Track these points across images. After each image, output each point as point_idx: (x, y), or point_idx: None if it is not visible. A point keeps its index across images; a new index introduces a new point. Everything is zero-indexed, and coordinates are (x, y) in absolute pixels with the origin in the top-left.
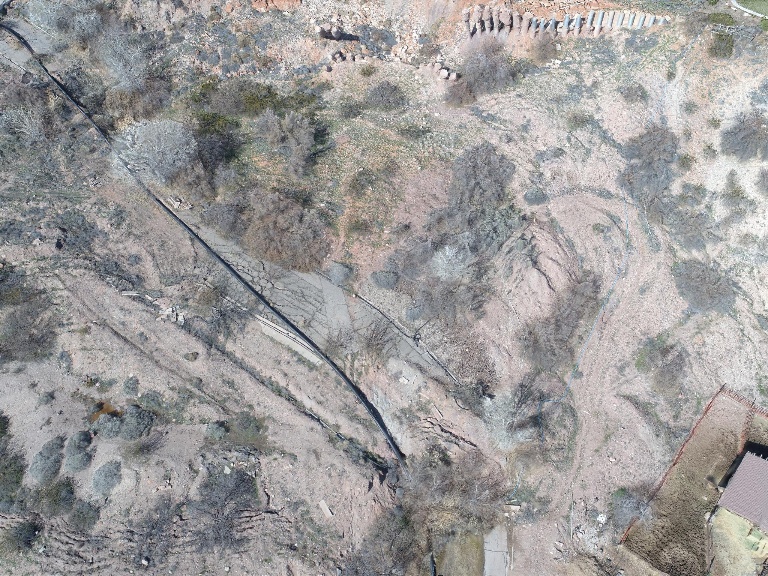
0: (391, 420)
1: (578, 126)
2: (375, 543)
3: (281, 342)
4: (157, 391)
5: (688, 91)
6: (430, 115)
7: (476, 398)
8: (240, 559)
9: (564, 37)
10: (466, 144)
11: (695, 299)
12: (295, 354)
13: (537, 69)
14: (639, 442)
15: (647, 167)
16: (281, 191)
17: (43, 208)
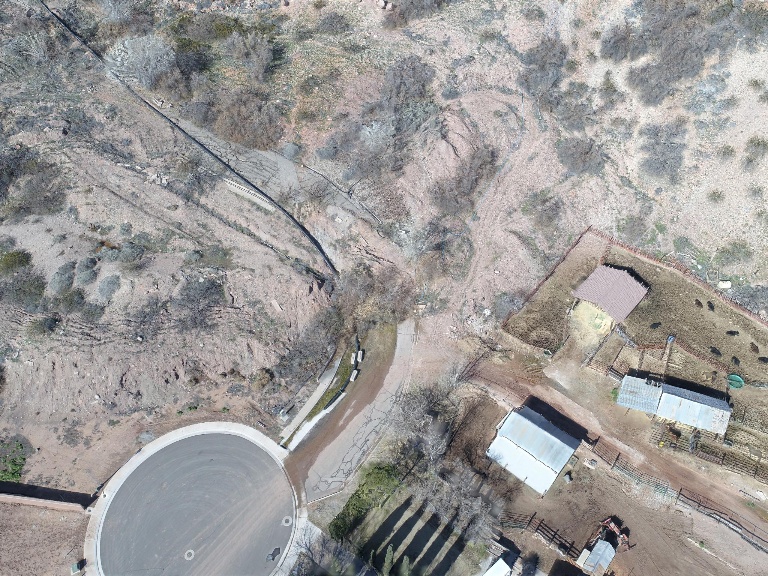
0: (328, 247)
1: (487, 40)
2: (315, 332)
3: (243, 196)
4: (146, 232)
5: (577, 11)
6: (370, 37)
7: (393, 230)
8: (212, 338)
9: None
10: (397, 57)
11: (572, 165)
12: (254, 204)
13: None
14: (518, 260)
15: (541, 70)
16: None
17: (50, 107)
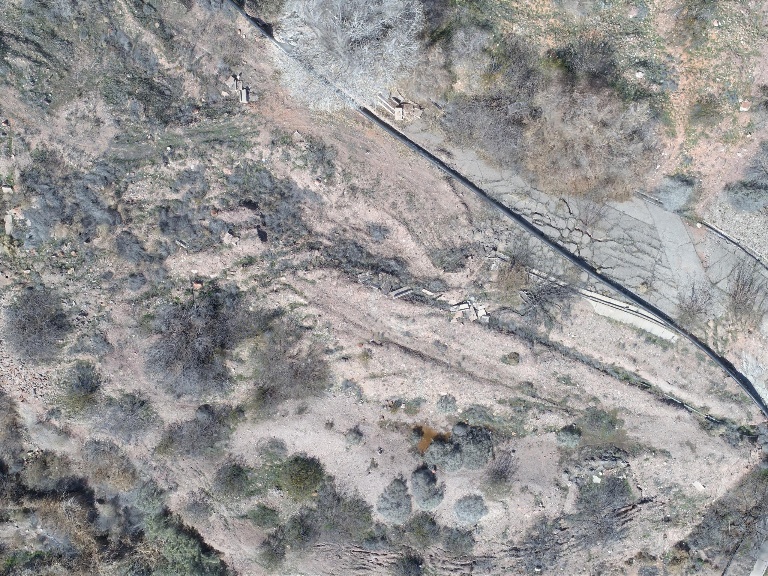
0: (766, 389)
1: None
2: (737, 490)
3: (622, 321)
4: (481, 405)
5: None
6: None
7: None
8: (622, 543)
9: None
10: None
11: None
12: (642, 333)
13: None
14: None
15: None
16: (564, 56)
17: (196, 169)
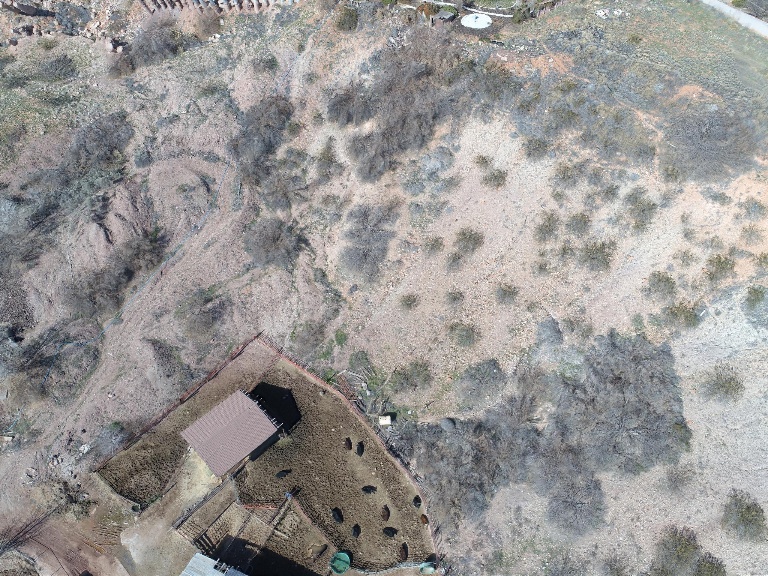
0: None
1: (205, 95)
2: None
3: None
4: None
5: (312, 62)
6: (89, 86)
7: None
8: None
9: (228, 13)
10: (104, 112)
11: (258, 254)
12: None
13: (199, 43)
14: (143, 380)
15: None
16: None
17: None
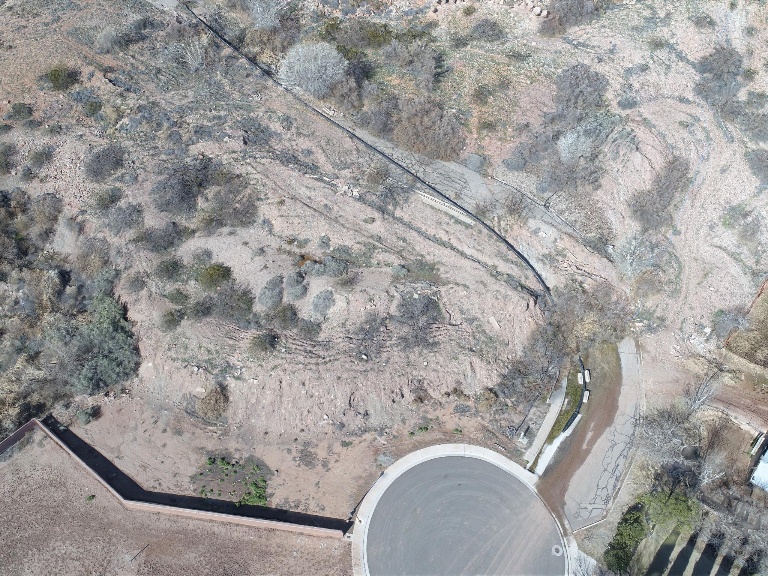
0: (536, 262)
1: (658, 48)
2: (532, 350)
3: (440, 209)
4: (346, 245)
5: (748, 18)
6: (528, 44)
7: (602, 244)
8: (435, 357)
9: None
10: (563, 65)
11: (765, 177)
12: (452, 217)
13: (616, 6)
14: (732, 277)
15: (718, 79)
16: None
17: (224, 116)
